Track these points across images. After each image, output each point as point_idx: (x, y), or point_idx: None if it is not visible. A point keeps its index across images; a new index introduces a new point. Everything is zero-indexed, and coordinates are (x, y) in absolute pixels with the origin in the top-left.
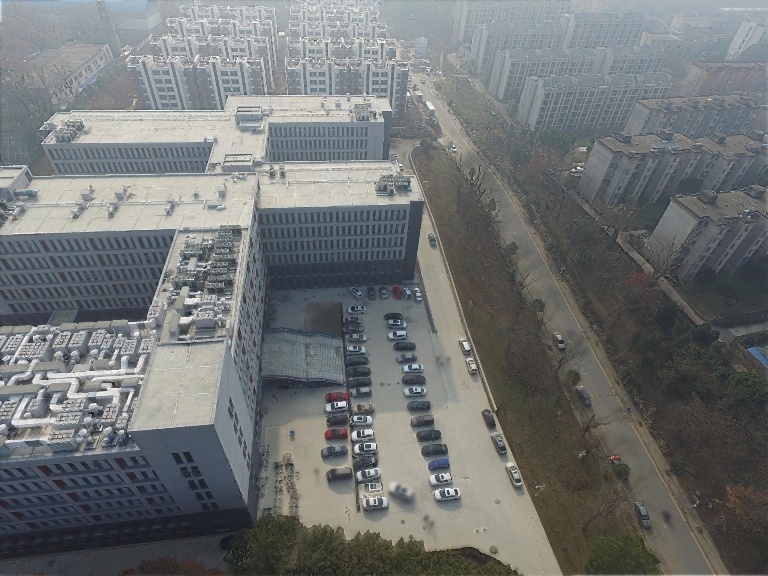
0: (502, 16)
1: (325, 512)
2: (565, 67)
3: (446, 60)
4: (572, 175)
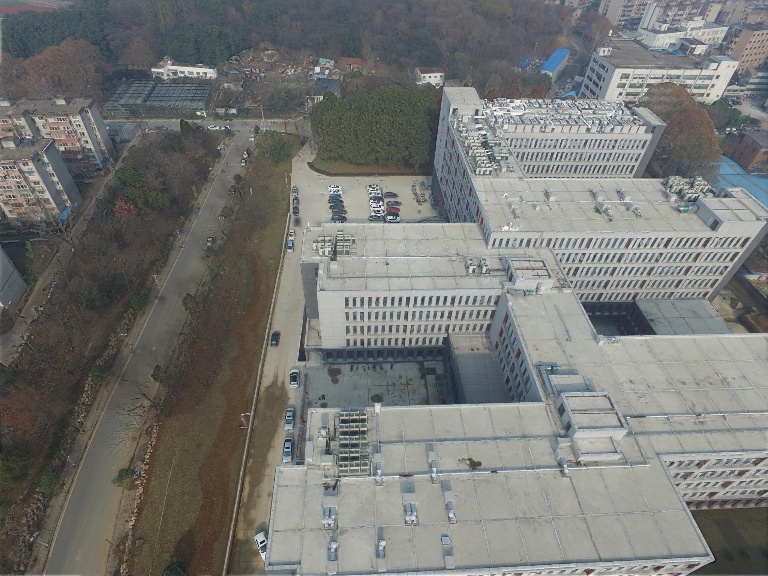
0: None
1: (398, 188)
2: None
3: None
4: None
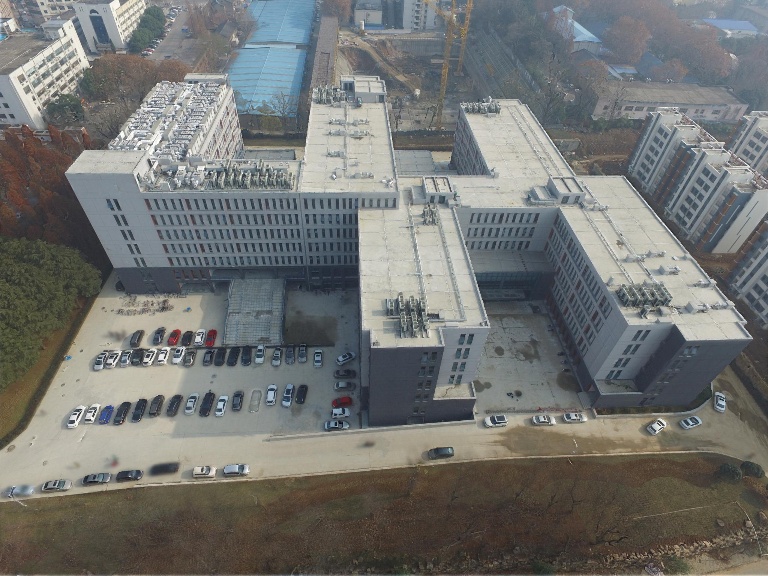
0: None
1: (115, 331)
2: None
3: None
4: None
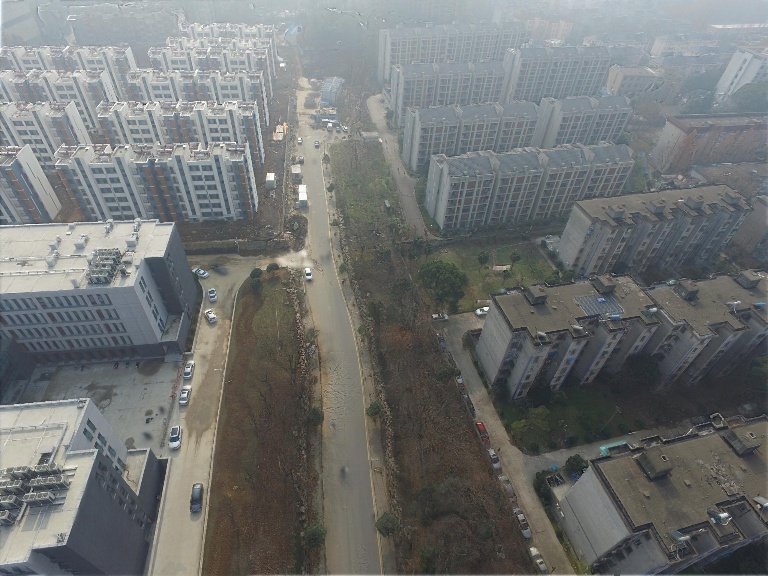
0: (437, 49)
1: None
2: (497, 129)
3: (364, 106)
4: (447, 364)
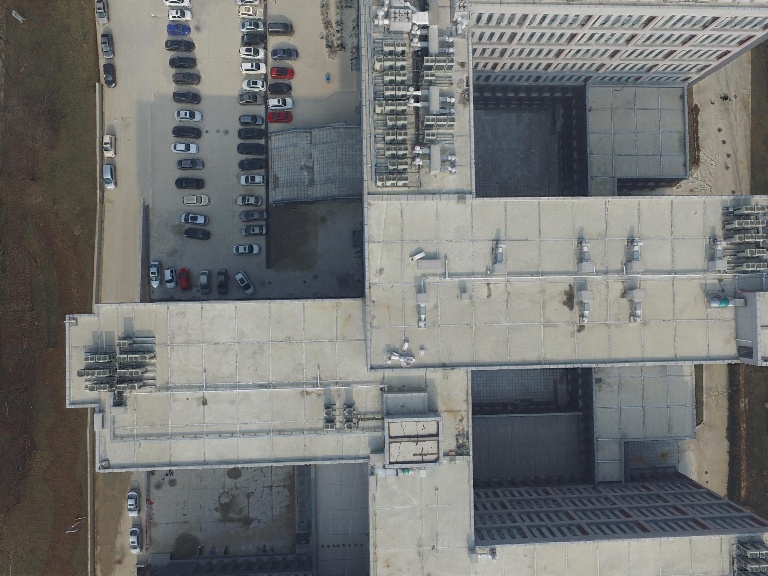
0: None
1: (296, 0)
2: None
3: None
4: None
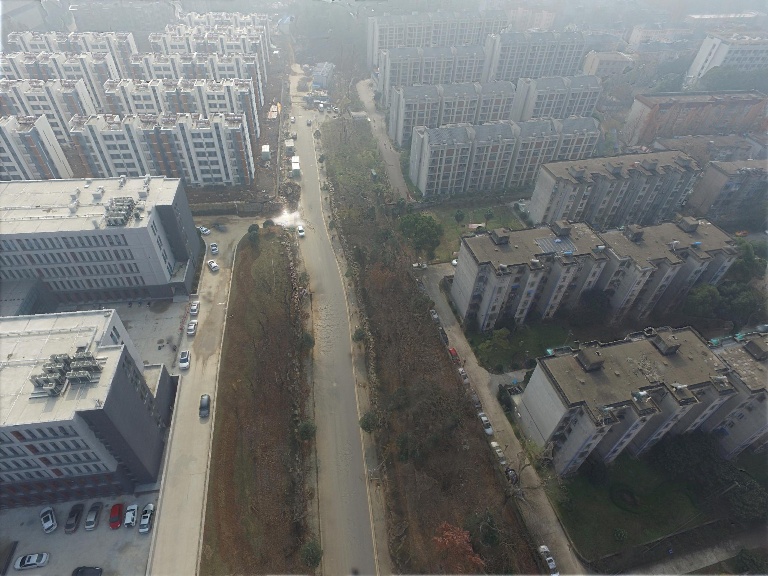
0: (423, 35)
1: None
2: (476, 106)
3: (353, 90)
4: (422, 295)
